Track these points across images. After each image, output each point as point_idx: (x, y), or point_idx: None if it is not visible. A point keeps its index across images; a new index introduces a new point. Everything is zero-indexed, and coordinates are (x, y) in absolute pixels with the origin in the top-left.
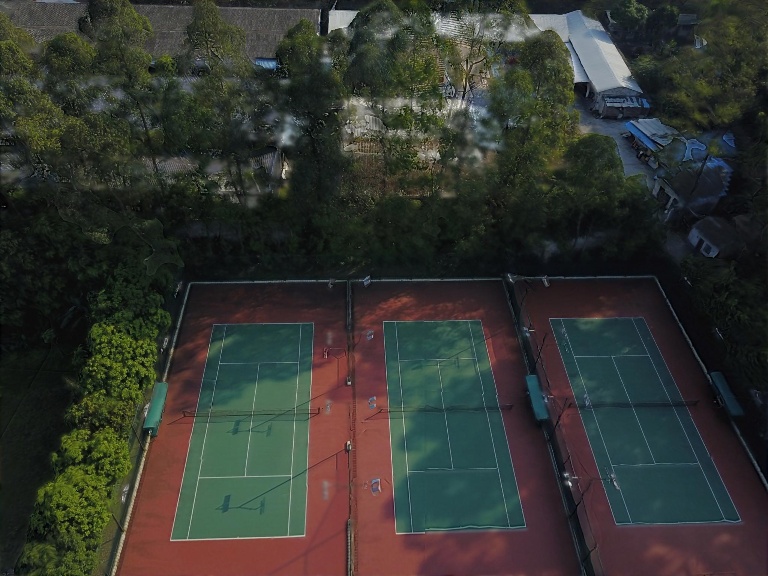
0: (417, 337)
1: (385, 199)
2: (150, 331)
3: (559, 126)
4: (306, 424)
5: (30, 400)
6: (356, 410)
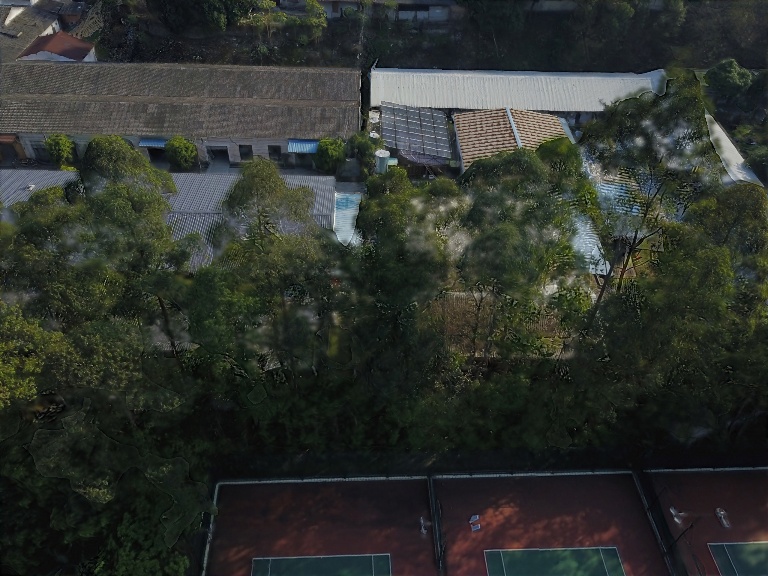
0: None
1: (490, 389)
2: None
3: (752, 311)
4: None
5: None
6: None
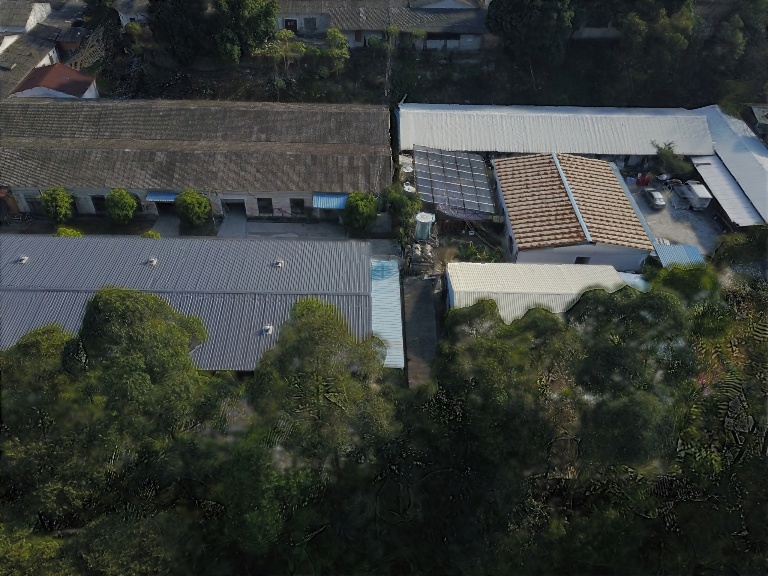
0: None
1: (580, 542)
2: None
3: None
4: None
5: None
6: None
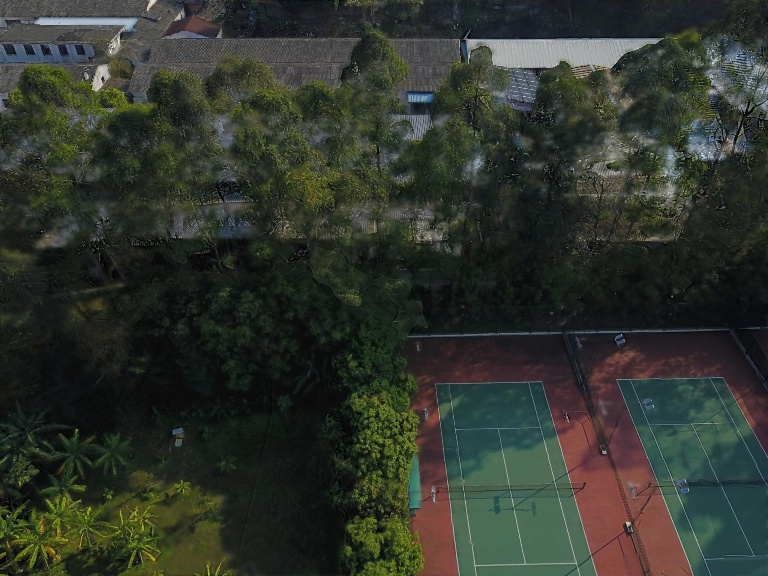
0: (660, 398)
1: (621, 248)
2: (404, 400)
3: None
4: (572, 501)
5: (266, 472)
6: (622, 484)
